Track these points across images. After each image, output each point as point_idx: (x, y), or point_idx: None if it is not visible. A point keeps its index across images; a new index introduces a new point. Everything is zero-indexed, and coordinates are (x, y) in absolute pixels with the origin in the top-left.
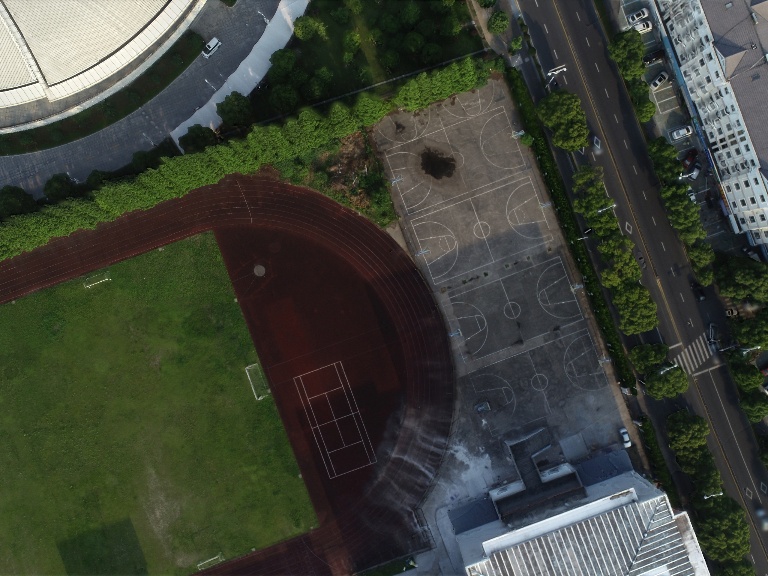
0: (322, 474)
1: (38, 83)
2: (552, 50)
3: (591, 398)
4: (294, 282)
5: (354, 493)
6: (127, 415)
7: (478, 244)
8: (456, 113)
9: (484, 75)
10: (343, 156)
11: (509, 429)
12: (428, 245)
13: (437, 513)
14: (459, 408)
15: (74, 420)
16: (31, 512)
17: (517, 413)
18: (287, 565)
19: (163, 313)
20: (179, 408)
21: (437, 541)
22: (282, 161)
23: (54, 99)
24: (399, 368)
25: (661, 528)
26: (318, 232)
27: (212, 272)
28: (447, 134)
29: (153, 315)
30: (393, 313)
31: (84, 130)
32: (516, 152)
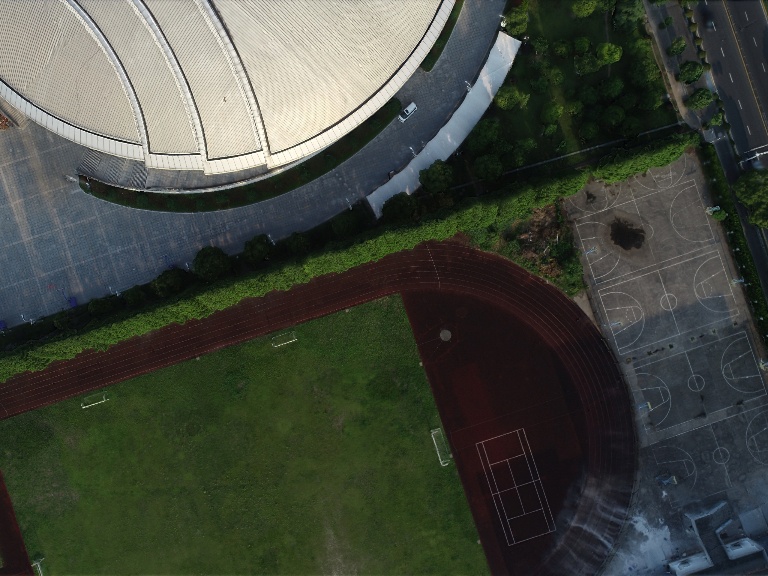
0: (501, 541)
1: (262, 151)
2: (745, 126)
3: None
4: (480, 348)
5: (532, 561)
6: (308, 475)
7: (664, 316)
8: (647, 185)
9: (682, 150)
10: (534, 224)
11: (689, 501)
12: (615, 315)
13: None
14: (640, 479)
15: (254, 479)
16: (208, 570)
17: (698, 486)
18: None
19: (348, 374)
20: (360, 470)
21: None
22: (478, 229)
23: (273, 166)
24: (581, 437)
25: None
26: (505, 299)
27: (398, 335)
28: (637, 205)
29: (338, 376)
30: (577, 382)
31: (278, 190)
32: (705, 226)
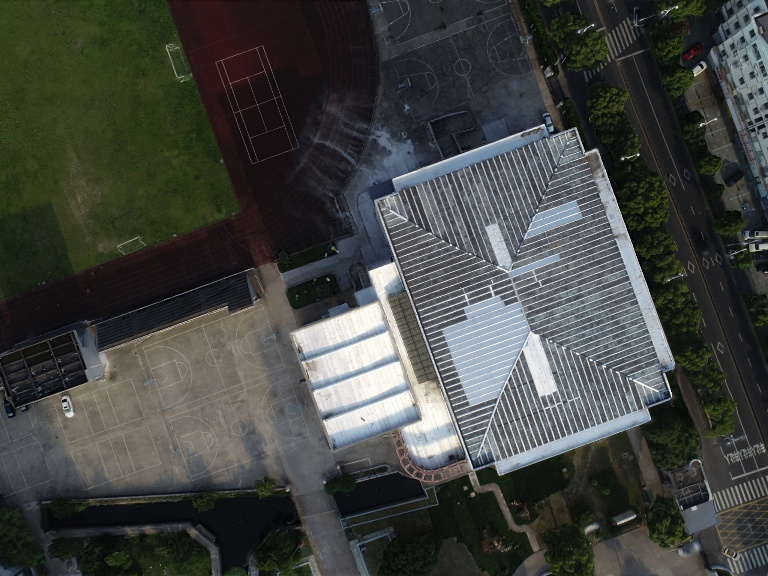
0: (244, 159)
1: None
2: None
3: (514, 84)
4: None
5: (276, 179)
6: (48, 99)
7: None
8: None
9: None
10: None
11: (432, 115)
12: None
13: (359, 198)
14: (382, 93)
15: None
16: None
17: (440, 98)
18: (208, 251)
19: None
20: (101, 92)
21: (359, 227)
22: None
23: None
24: (322, 53)
25: (571, 164)
26: None
27: None
28: None
29: None
30: None
31: None
32: None
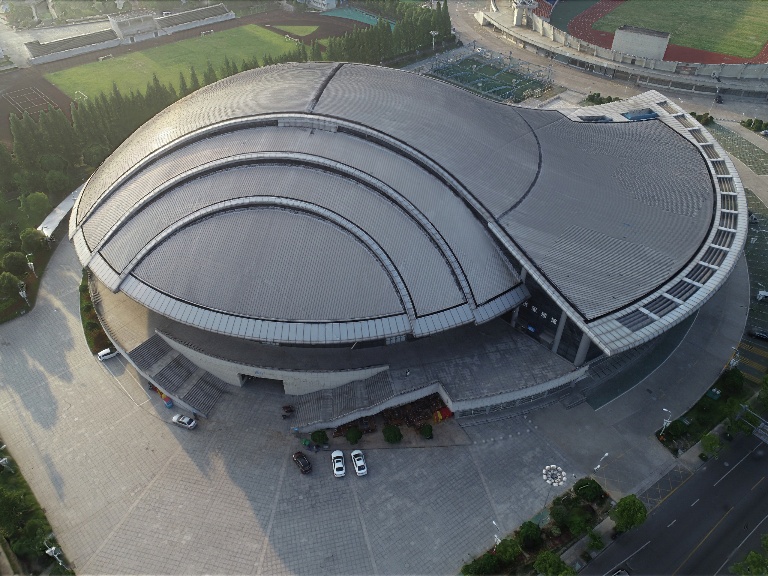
0: None
1: None
2: None
3: None
4: None
5: None
6: None
7: None
8: None
9: None
10: None
11: None
12: None
13: None
14: None
15: None
16: None
17: None
18: None
19: None
20: (133, 88)
21: None
22: None
23: None
24: None
25: None
26: None
27: None
28: None
29: None
30: None
31: None
32: None
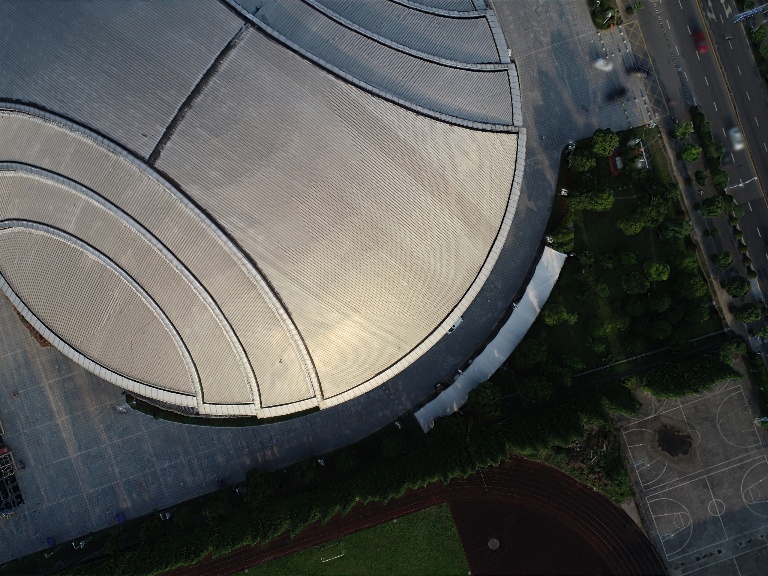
0: None
1: (315, 398)
2: None
3: None
4: (528, 556)
5: None
6: None
7: (712, 521)
8: None
9: (729, 362)
10: None
11: None
12: (663, 522)
13: None
14: None
15: None
16: None
17: None
18: None
19: None
20: None
21: None
22: None
23: (325, 407)
24: None
25: None
26: (553, 507)
27: (446, 545)
28: (684, 412)
29: None
30: None
31: None
32: (752, 431)
